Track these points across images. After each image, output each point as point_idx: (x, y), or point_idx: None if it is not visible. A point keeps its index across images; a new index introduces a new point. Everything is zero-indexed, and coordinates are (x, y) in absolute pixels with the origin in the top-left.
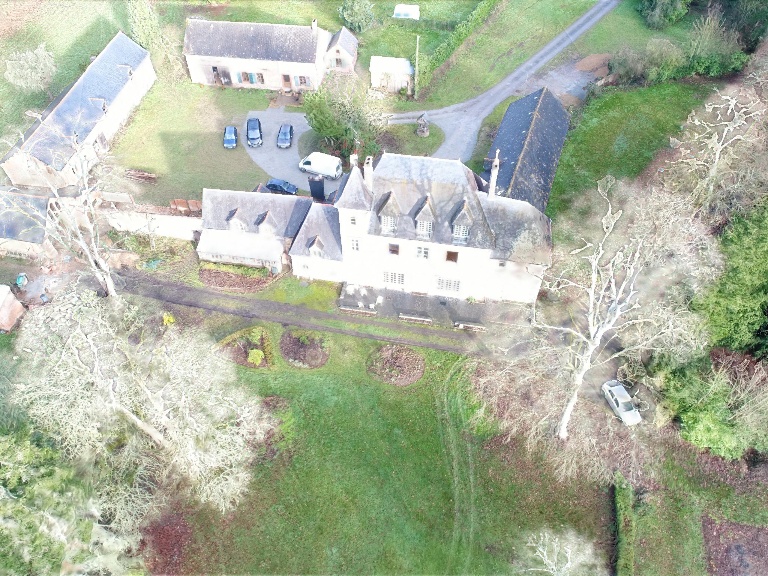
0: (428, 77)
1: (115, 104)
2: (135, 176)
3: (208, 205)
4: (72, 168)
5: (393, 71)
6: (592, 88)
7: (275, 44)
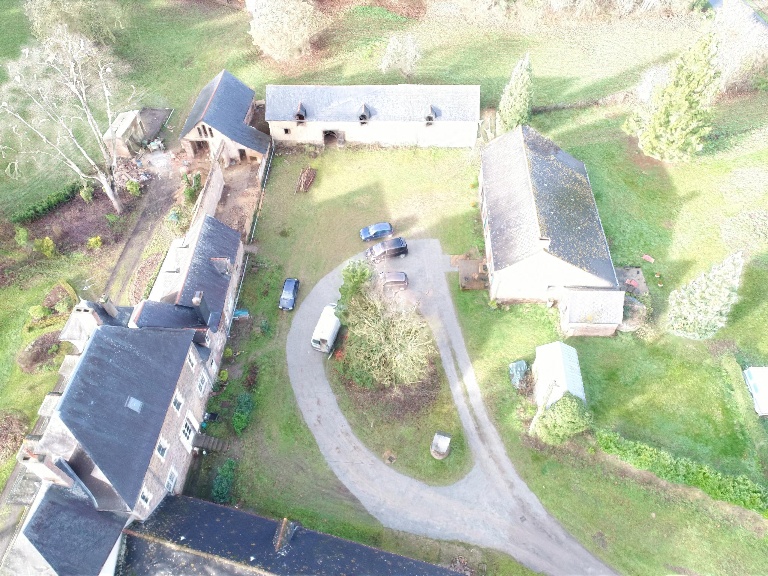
0: (548, 436)
1: (381, 125)
2: (303, 175)
3: (196, 225)
4: (285, 128)
5: (542, 379)
6: None
7: (511, 218)
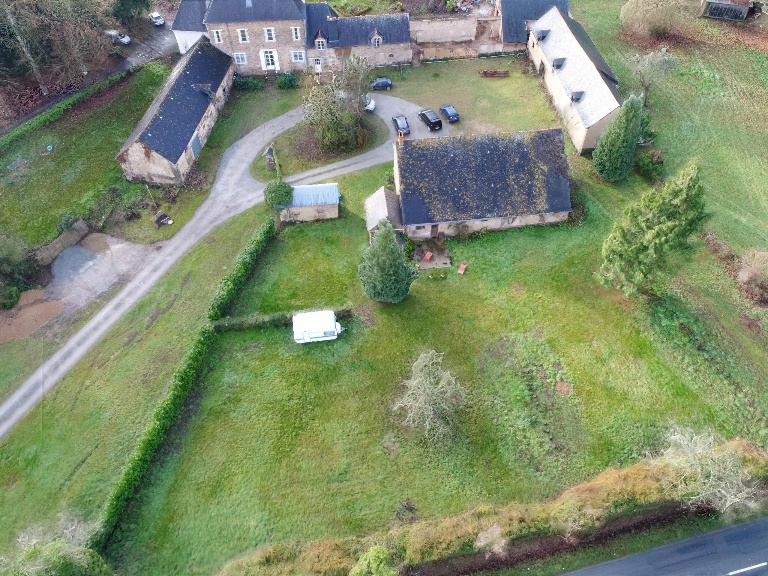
0: None
1: None
2: None
3: None
4: None
5: None
6: (71, 215)
7: None
